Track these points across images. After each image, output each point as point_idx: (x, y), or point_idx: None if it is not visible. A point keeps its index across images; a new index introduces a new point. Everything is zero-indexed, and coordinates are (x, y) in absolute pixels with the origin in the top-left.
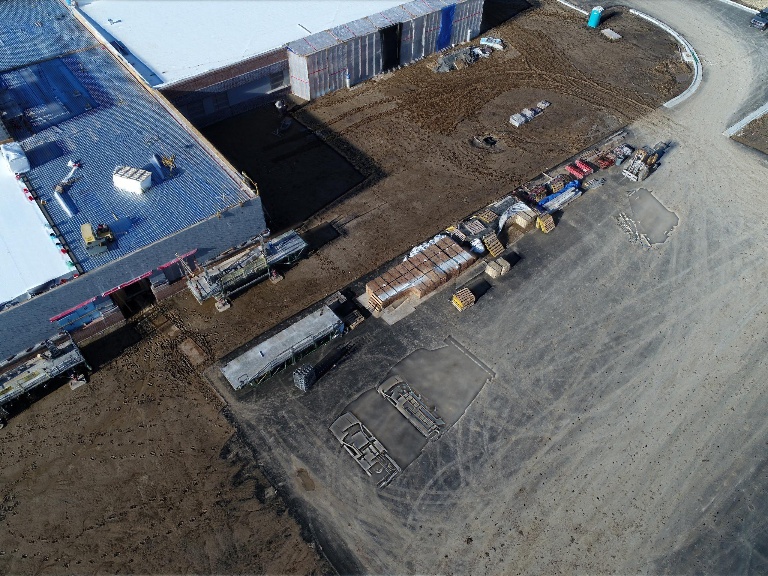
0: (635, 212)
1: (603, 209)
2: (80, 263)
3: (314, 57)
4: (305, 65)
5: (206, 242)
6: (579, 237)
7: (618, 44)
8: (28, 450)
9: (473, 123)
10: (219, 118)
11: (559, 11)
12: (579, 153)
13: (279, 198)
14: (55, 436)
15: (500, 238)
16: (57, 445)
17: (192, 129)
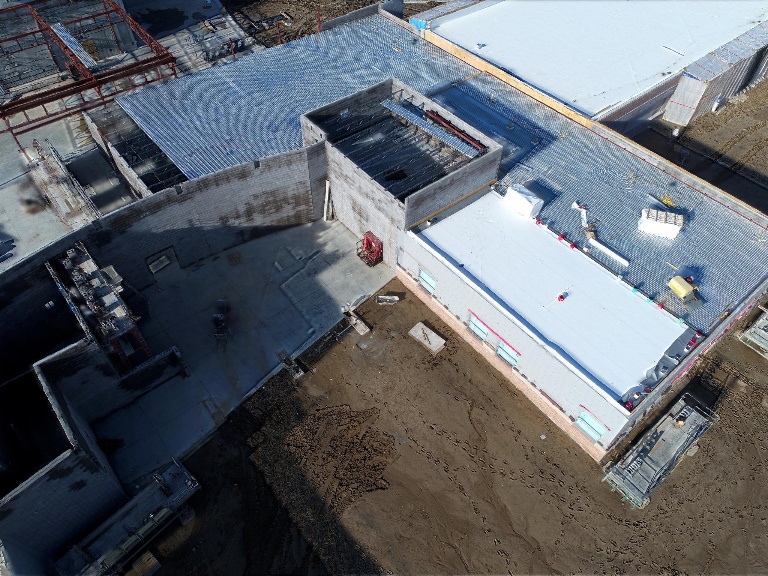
0: None
1: None
2: (685, 320)
3: (712, 82)
4: (702, 91)
5: (761, 291)
6: None
7: None
8: (694, 527)
9: None
10: None
11: None
12: None
13: None
14: (710, 510)
15: None
16: (719, 521)
17: (673, 165)
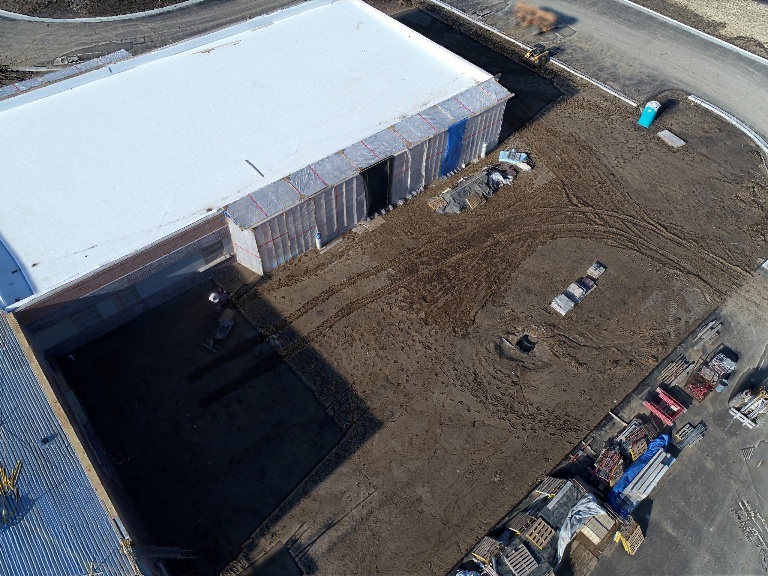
0: (762, 497)
1: (712, 492)
2: None
3: (265, 226)
4: (252, 237)
5: None
6: (684, 562)
7: (682, 155)
8: None
9: (499, 310)
10: (126, 318)
11: (598, 101)
12: (658, 367)
13: (206, 489)
14: None
15: (559, 570)
16: None
17: (54, 407)
